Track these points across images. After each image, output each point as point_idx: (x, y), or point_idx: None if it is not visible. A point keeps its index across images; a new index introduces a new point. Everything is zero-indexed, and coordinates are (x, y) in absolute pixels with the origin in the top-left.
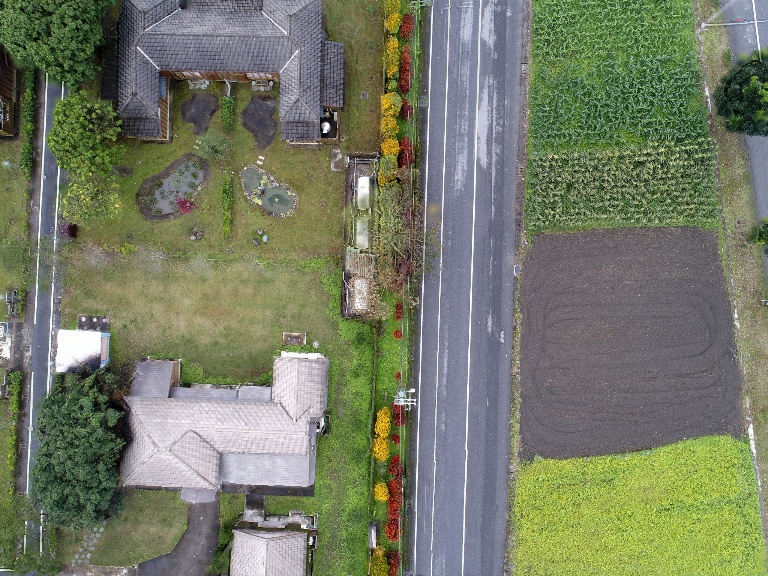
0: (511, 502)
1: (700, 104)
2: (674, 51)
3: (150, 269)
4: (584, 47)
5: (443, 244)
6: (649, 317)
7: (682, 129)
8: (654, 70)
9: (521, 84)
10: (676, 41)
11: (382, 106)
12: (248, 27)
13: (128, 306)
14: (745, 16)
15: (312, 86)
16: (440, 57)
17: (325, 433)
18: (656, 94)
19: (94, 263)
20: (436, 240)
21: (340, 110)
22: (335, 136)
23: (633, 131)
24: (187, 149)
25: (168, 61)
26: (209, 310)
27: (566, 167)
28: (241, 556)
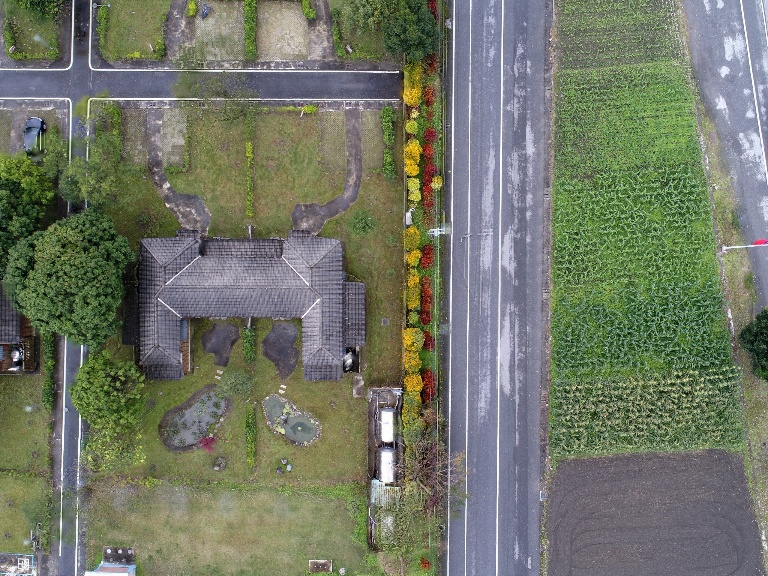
0: None
1: (723, 329)
2: (696, 277)
3: (174, 499)
4: (605, 275)
5: (468, 472)
6: (676, 539)
7: (706, 357)
8: (676, 298)
9: (542, 310)
10: (698, 267)
11: (403, 334)
12: (269, 277)
13: (153, 537)
14: (766, 238)
15: (334, 332)
16: (461, 285)
17: None
18: (679, 323)
19: (118, 494)
20: (461, 467)
21: None
22: (357, 371)
23: (656, 358)
24: (209, 379)
25: (189, 310)
26: (234, 539)
27: (590, 396)
28: None
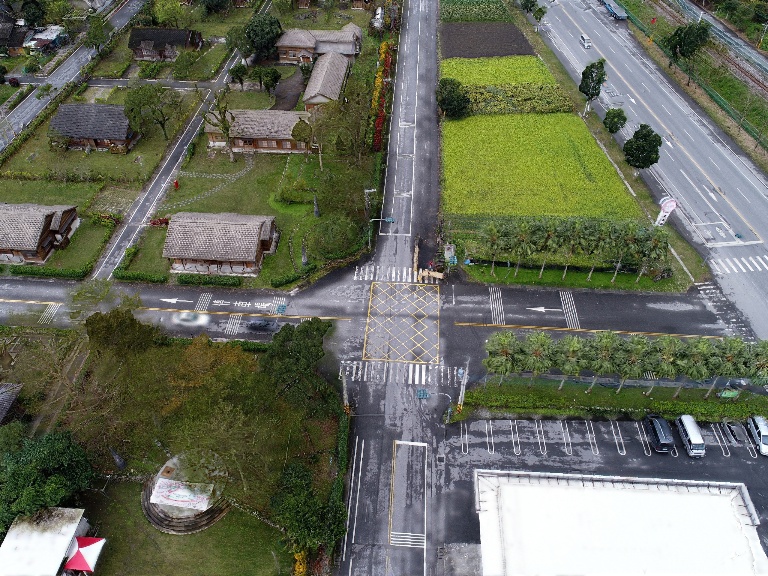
0: (438, 67)
1: None
2: None
3: None
4: None
5: None
6: None
7: None
8: None
9: (436, 0)
10: None
11: None
12: None
13: None
14: None
15: None
16: None
17: (358, 55)
18: None
19: None
20: (406, 22)
21: (371, 1)
22: (369, 2)
23: (477, 4)
24: None
25: None
26: None
27: None
28: (320, 59)
